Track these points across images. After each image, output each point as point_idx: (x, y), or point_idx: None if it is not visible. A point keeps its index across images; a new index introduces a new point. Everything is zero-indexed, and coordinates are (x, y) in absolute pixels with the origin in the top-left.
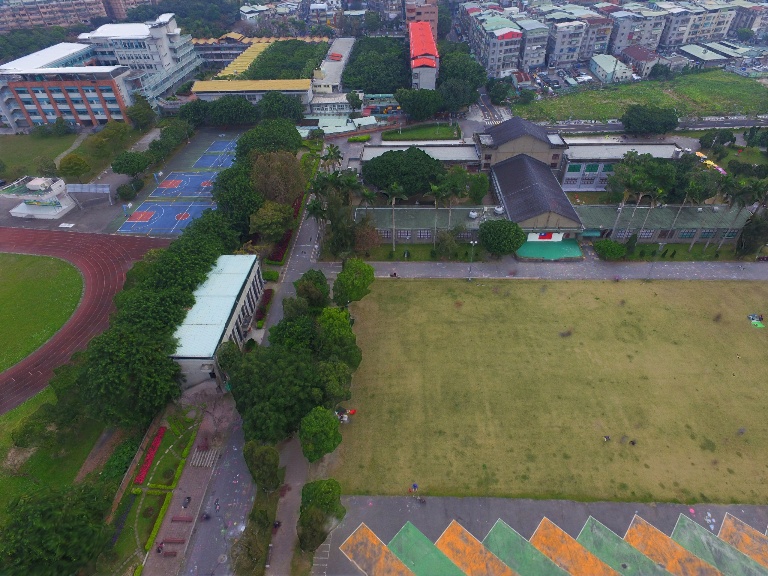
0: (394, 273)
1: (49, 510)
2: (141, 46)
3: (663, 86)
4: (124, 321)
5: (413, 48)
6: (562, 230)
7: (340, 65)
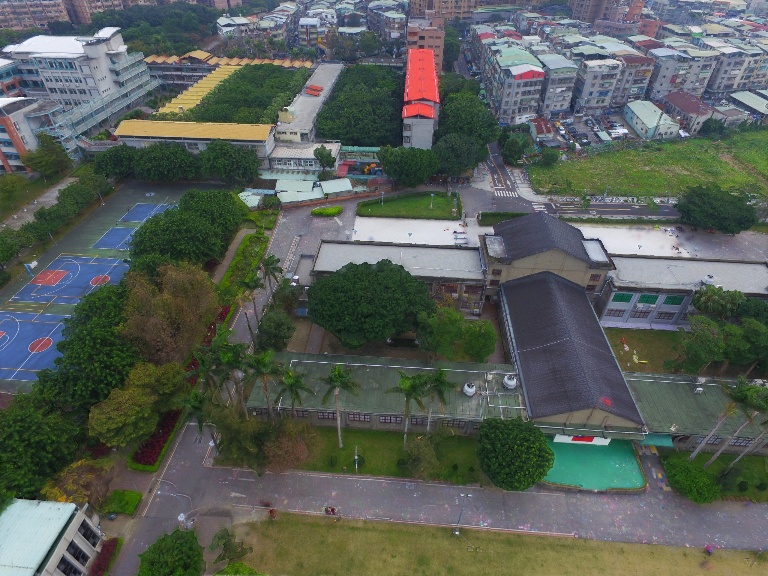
0: (331, 510)
1: None
2: (72, 66)
3: (718, 148)
4: None
5: (408, 87)
6: (611, 433)
7: (317, 102)
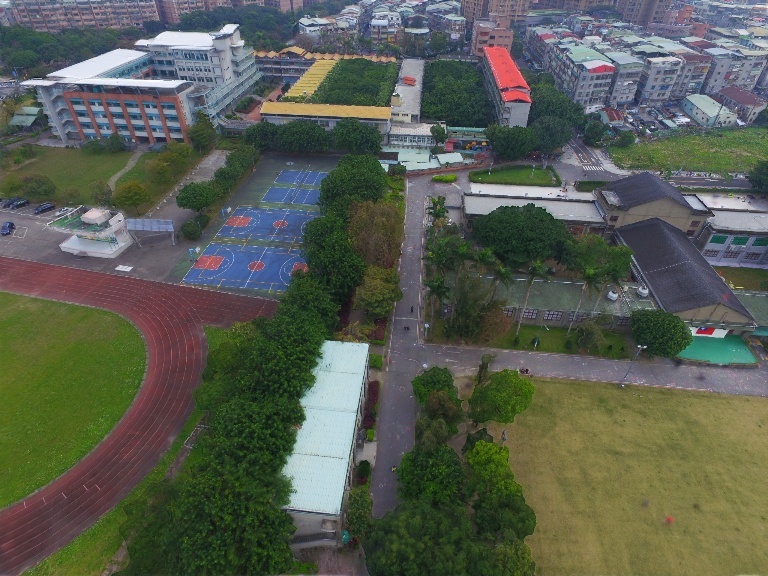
0: (526, 369)
1: None
2: (203, 58)
3: None
4: (224, 455)
5: (498, 77)
6: (729, 326)
7: (416, 91)
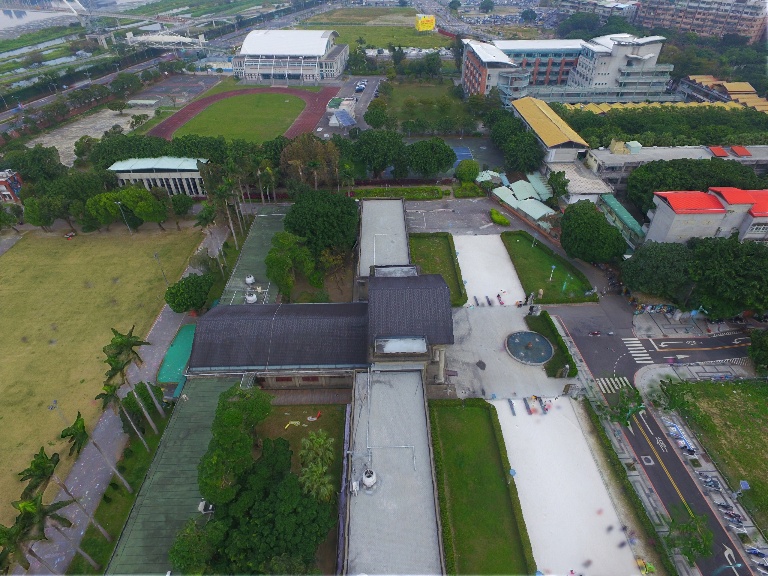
0: None
1: (38, 152)
2: None
3: None
4: None
5: None
6: None
7: None
